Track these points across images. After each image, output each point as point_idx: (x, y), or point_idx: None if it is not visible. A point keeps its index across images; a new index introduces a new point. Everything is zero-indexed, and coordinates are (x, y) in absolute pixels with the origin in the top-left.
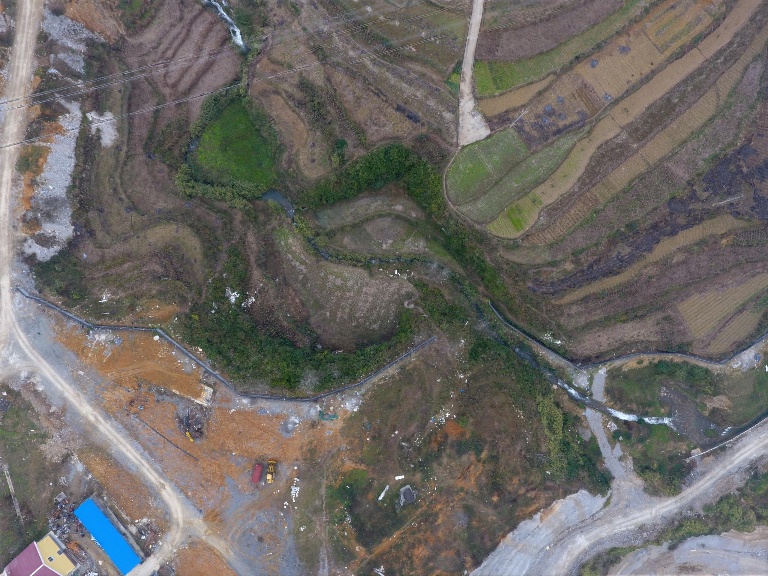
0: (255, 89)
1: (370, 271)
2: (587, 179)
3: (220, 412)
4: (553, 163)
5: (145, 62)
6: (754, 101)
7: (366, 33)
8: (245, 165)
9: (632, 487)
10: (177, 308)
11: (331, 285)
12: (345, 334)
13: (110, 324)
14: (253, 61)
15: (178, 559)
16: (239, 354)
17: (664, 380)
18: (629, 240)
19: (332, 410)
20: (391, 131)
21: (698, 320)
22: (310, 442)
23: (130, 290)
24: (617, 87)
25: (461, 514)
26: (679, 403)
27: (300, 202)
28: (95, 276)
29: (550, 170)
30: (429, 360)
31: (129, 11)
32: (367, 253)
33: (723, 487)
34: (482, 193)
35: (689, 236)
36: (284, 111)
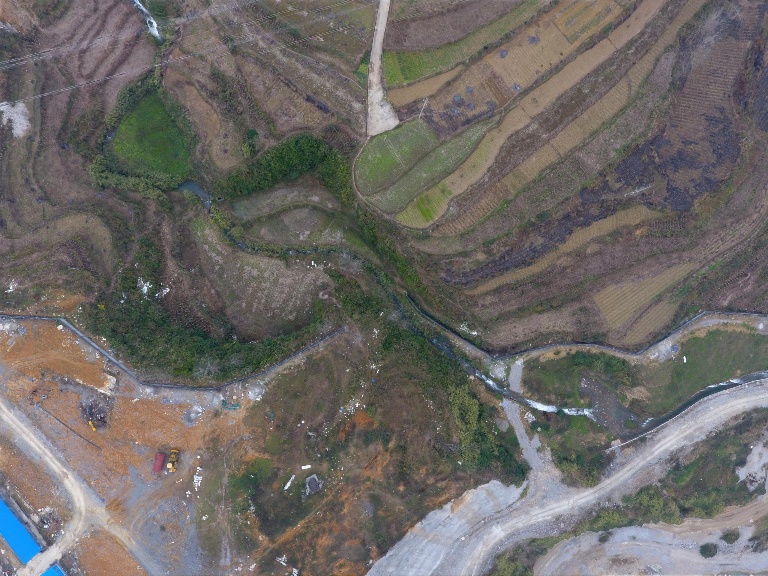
0: (169, 80)
1: (286, 262)
2: (497, 169)
3: (123, 401)
4: (462, 153)
5: (59, 53)
6: (666, 92)
7: (274, 23)
8: (161, 156)
9: (549, 478)
10: (82, 298)
11: (247, 276)
12: (261, 325)
13: (14, 313)
14: (166, 52)
15: (80, 548)
16: (146, 344)
17: (584, 371)
18: (541, 230)
19: (235, 399)
20: (301, 121)
21: (614, 311)
22: (213, 431)
23: (37, 280)
24: (526, 77)
25: (367, 504)
26: (599, 394)
27: (215, 193)
28: (4, 266)
29: (459, 160)
30: (338, 350)
31: (41, 2)
32: (284, 244)
33: (644, 478)
34: (391, 183)
35: (603, 227)
36: (198, 102)
